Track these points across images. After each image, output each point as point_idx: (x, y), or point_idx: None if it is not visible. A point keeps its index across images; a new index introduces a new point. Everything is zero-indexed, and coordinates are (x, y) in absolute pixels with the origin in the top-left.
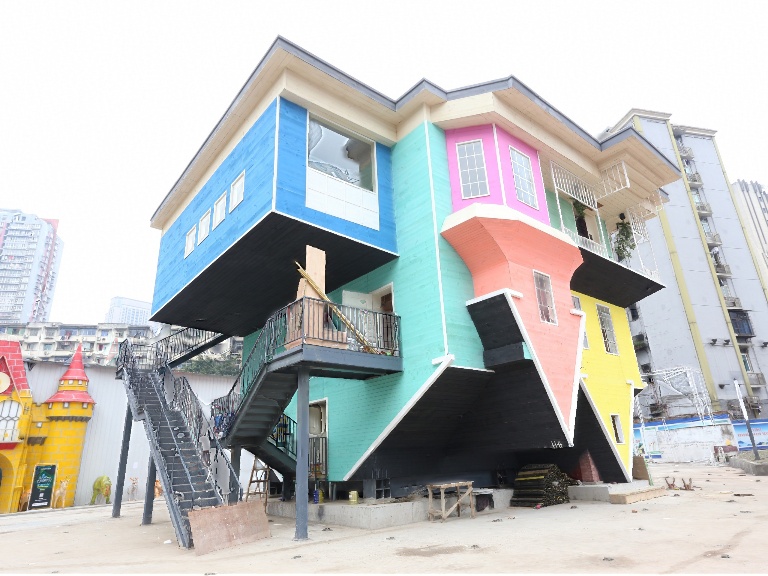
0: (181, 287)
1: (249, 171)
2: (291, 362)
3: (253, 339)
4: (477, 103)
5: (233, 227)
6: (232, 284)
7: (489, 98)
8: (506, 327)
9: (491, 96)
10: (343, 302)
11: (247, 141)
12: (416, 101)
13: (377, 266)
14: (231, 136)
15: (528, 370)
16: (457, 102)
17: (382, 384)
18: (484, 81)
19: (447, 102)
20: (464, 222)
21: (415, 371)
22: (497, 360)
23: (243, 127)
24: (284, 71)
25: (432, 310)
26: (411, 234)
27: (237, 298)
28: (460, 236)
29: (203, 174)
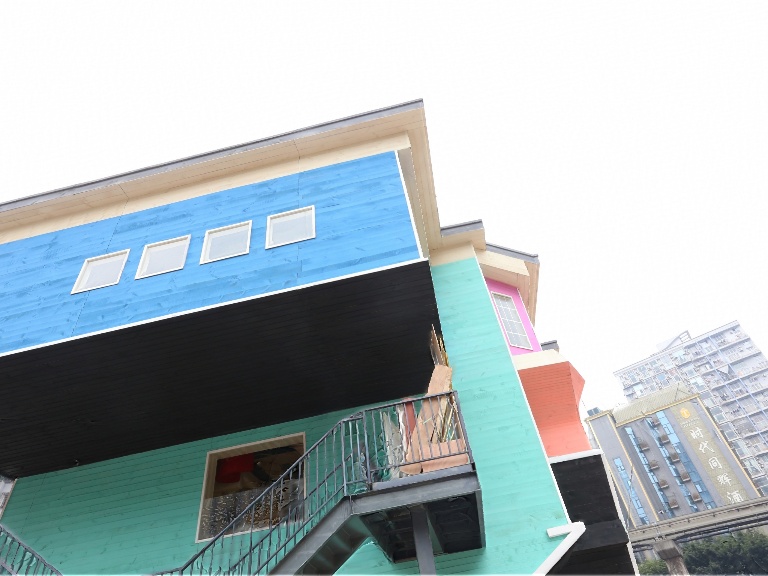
0: (51, 337)
1: (328, 209)
2: (438, 495)
3: (52, 483)
4: (514, 264)
5: (284, 267)
6: (179, 359)
7: (523, 264)
8: (597, 498)
9: (524, 263)
10: (386, 428)
11: (313, 178)
12: (466, 236)
13: (412, 393)
14: (259, 166)
15: (619, 559)
16: (496, 255)
17: (438, 570)
18: (516, 249)
19: (487, 251)
20: (553, 364)
21: (511, 547)
22: (587, 542)
23: (297, 163)
24: (406, 133)
25: (529, 460)
26: (471, 364)
27: (143, 389)
28: (537, 380)
29: (157, 192)
